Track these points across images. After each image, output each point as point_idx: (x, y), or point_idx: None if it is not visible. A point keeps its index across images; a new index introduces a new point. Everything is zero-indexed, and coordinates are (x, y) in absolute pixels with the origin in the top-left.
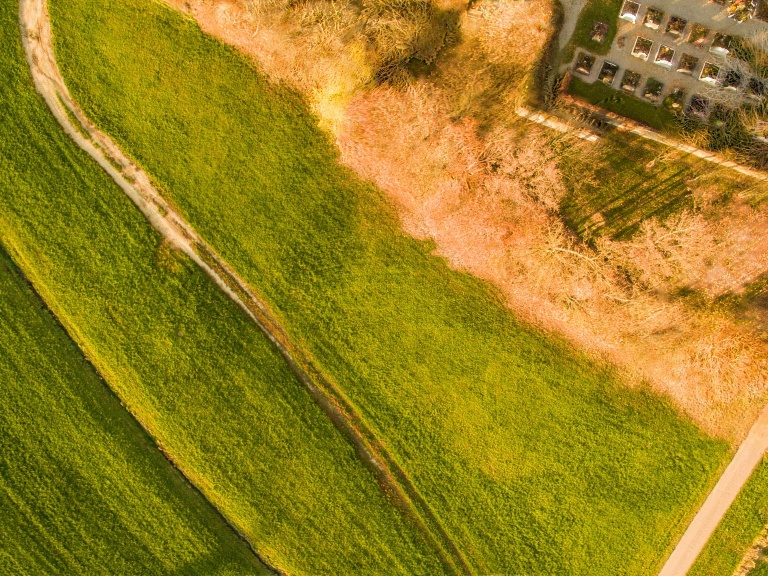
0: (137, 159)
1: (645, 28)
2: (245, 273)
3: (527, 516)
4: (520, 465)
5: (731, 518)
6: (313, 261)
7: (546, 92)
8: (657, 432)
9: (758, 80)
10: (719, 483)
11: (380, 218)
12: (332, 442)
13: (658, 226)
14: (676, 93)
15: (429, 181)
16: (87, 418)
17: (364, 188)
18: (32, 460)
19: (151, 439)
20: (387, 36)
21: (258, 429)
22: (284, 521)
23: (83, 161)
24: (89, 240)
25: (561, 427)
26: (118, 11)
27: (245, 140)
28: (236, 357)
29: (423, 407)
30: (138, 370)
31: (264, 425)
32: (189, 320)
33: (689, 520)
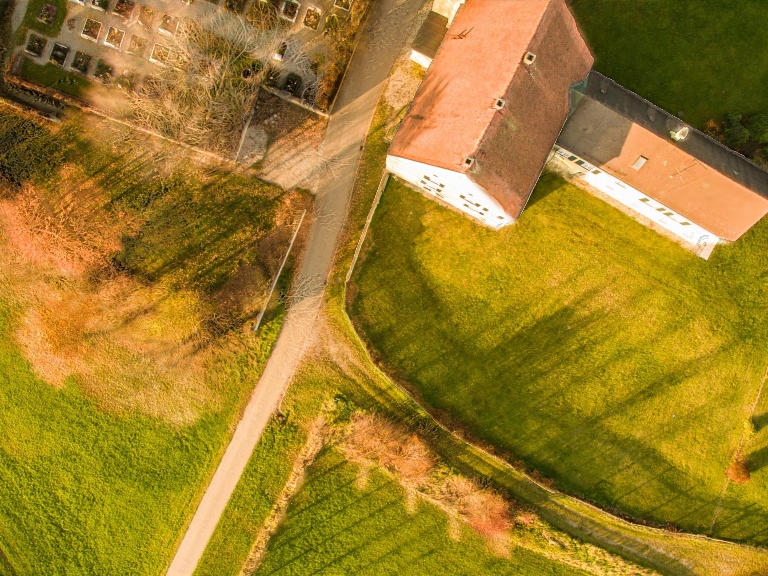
0: None
1: (93, 10)
2: None
3: (50, 495)
4: (39, 445)
5: (239, 498)
6: None
7: (4, 74)
8: (163, 412)
9: (207, 61)
10: (222, 463)
11: None
12: None
13: (129, 207)
14: (126, 74)
15: None
16: None
17: None
18: None
19: None
20: None
21: None
22: None
23: None
24: None
25: (73, 407)
26: None
27: None
28: None
29: None
30: None
31: None
32: None
33: (198, 500)
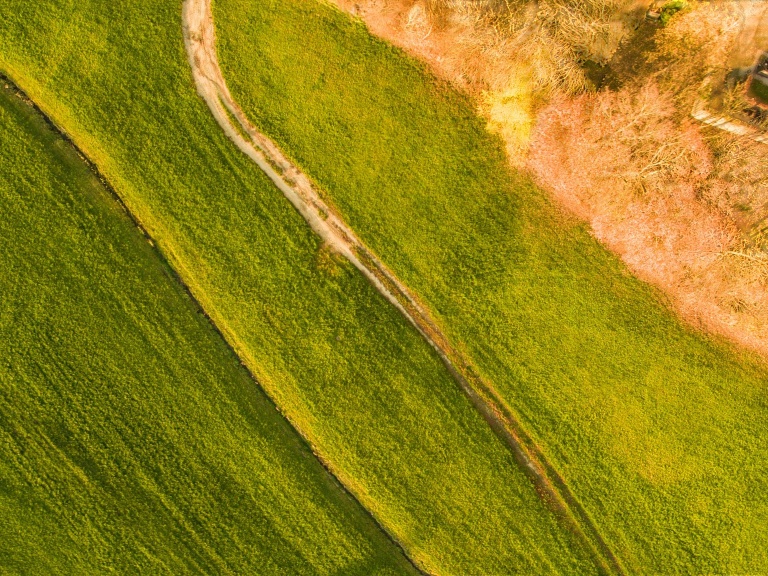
0: (298, 162)
1: None
2: (405, 277)
3: (684, 520)
4: (679, 469)
5: None
6: (475, 265)
7: (725, 95)
8: None
9: None
10: None
11: (544, 221)
12: (489, 446)
13: None
14: None
15: (598, 184)
16: (242, 423)
17: (529, 191)
18: (186, 466)
19: (306, 444)
20: (562, 38)
21: (415, 434)
22: (439, 526)
23: (244, 164)
24: (248, 244)
25: (722, 431)
26: (284, 13)
27: (409, 143)
28: (395, 361)
29: (582, 411)
30: (295, 375)
31: (421, 430)
32: (348, 324)
33: None
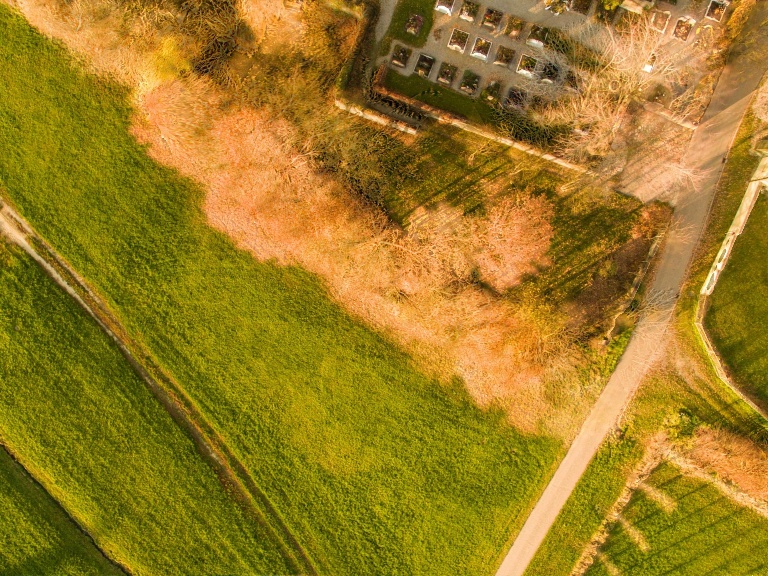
0: None
1: (461, 20)
2: (81, 267)
3: (367, 511)
4: (358, 460)
5: (568, 514)
6: (148, 255)
7: (364, 85)
8: (493, 427)
9: (575, 72)
10: (554, 478)
11: (212, 212)
12: (171, 437)
13: (482, 220)
14: (493, 86)
15: (257, 175)
16: None
17: (196, 182)
18: None
19: None
20: (208, 29)
21: (97, 423)
22: (125, 516)
23: None
24: None
25: (397, 422)
26: None
27: (76, 134)
28: (73, 351)
29: (261, 402)
30: None
31: (103, 419)
32: (26, 314)
33: (526, 515)
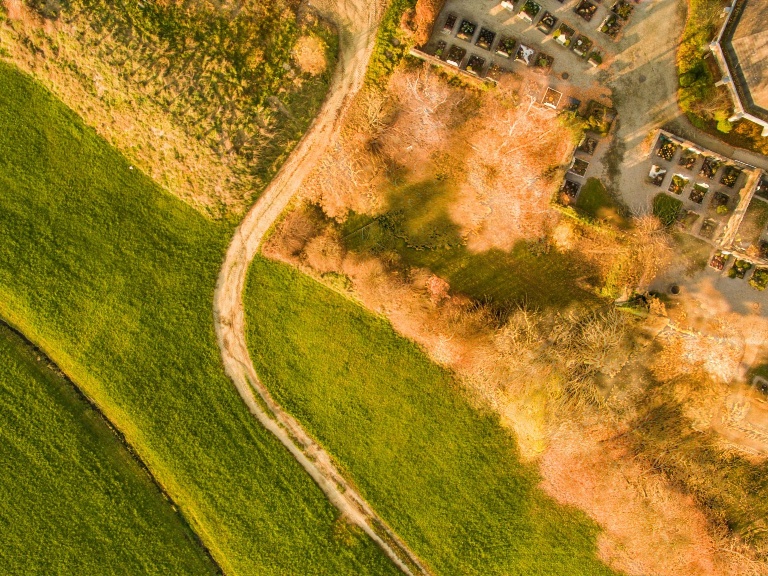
0: (320, 440)
1: None
2: (417, 547)
3: None
4: None
5: None
6: (483, 539)
7: (724, 414)
8: None
9: None
10: None
11: (550, 504)
12: None
13: None
14: None
15: (602, 477)
16: None
17: (537, 476)
18: None
19: None
20: (576, 351)
21: None
22: None
23: (267, 440)
24: (268, 513)
25: None
26: (312, 306)
27: (426, 428)
28: None
29: None
30: None
31: None
32: None
33: None
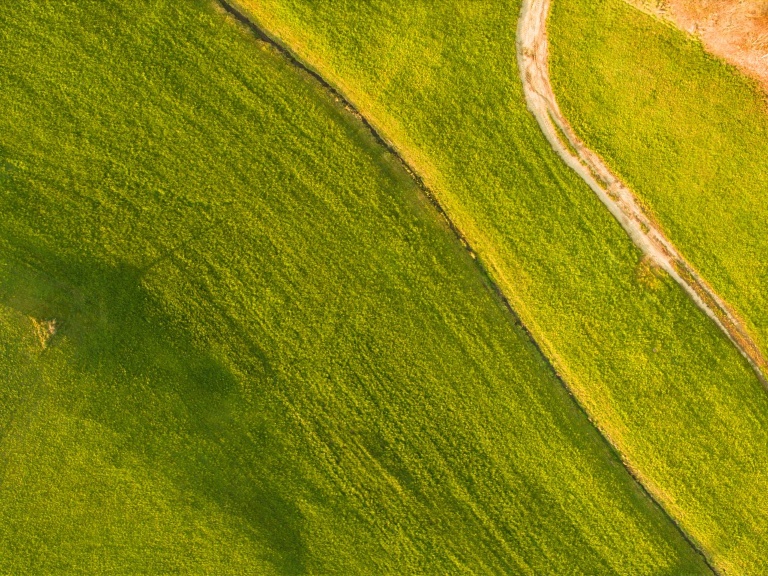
0: (623, 177)
1: None
2: (722, 290)
3: None
4: None
5: None
6: None
7: None
8: None
9: None
10: None
11: None
12: None
13: None
14: None
15: None
16: (556, 433)
17: None
18: (498, 475)
19: (615, 454)
20: None
21: (725, 444)
22: (744, 535)
23: (569, 178)
24: (570, 257)
25: None
26: (620, 30)
27: (736, 159)
28: (709, 373)
29: None
30: (610, 386)
31: (731, 440)
32: (665, 336)
33: None
